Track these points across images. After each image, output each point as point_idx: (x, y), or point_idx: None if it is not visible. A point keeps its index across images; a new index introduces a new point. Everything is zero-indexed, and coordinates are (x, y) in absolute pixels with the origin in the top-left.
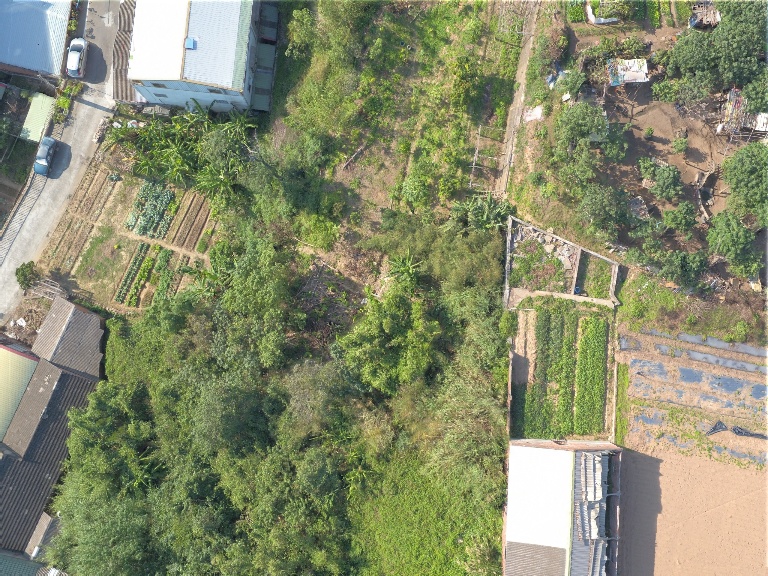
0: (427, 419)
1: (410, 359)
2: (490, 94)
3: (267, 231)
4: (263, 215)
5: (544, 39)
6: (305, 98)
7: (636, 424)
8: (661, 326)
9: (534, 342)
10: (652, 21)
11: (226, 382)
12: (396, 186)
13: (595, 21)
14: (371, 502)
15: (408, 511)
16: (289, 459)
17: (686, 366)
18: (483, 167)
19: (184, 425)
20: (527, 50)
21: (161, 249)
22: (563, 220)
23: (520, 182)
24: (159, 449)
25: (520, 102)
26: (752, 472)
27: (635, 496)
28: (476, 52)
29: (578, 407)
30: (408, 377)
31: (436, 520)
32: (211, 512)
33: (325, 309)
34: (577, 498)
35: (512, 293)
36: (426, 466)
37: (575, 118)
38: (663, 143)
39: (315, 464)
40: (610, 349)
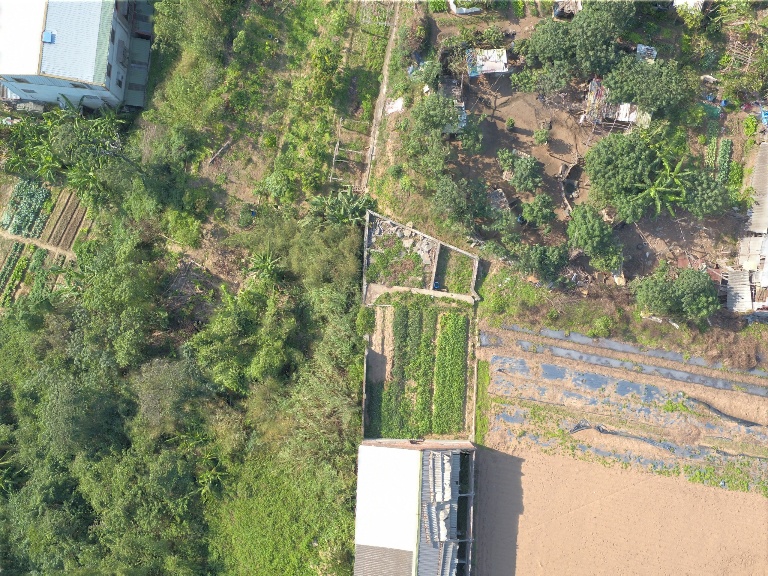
0: (279, 419)
1: (263, 357)
2: (356, 87)
3: (137, 229)
4: (133, 212)
5: (403, 29)
6: (172, 92)
7: (497, 422)
8: (522, 322)
9: (391, 339)
10: (516, 11)
11: (82, 383)
12: (261, 181)
13: (457, 11)
14: (227, 505)
15: (262, 514)
16: (143, 461)
17: (549, 362)
18: (349, 161)
19: (43, 428)
20: (390, 41)
21: (36, 248)
22: (423, 214)
23: (381, 175)
24: (18, 453)
25: (382, 94)
26: (617, 471)
27: (496, 497)
28: (342, 44)
29: (437, 405)
30: (260, 376)
31: (290, 523)
32: (68, 517)
33: (191, 308)
34: (425, 499)
35: (370, 289)
36: (280, 467)
37: (426, 109)
38: (527, 135)
39: (164, 466)
40: (470, 346)
